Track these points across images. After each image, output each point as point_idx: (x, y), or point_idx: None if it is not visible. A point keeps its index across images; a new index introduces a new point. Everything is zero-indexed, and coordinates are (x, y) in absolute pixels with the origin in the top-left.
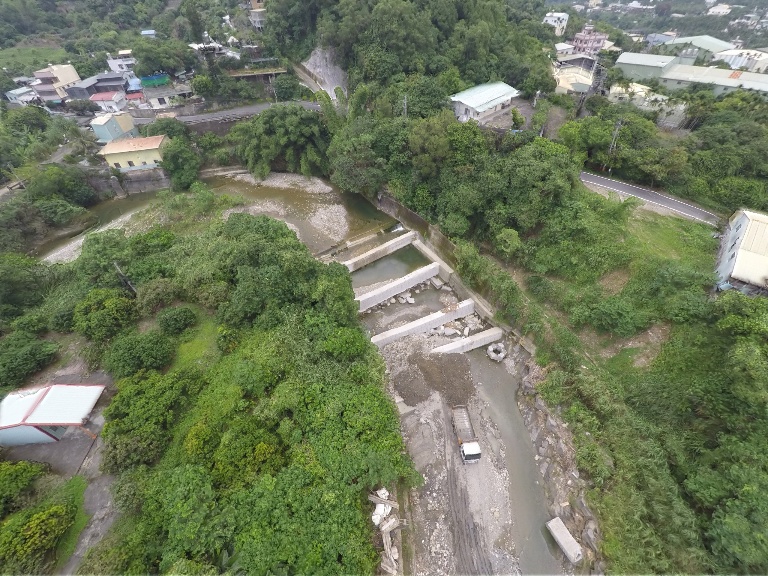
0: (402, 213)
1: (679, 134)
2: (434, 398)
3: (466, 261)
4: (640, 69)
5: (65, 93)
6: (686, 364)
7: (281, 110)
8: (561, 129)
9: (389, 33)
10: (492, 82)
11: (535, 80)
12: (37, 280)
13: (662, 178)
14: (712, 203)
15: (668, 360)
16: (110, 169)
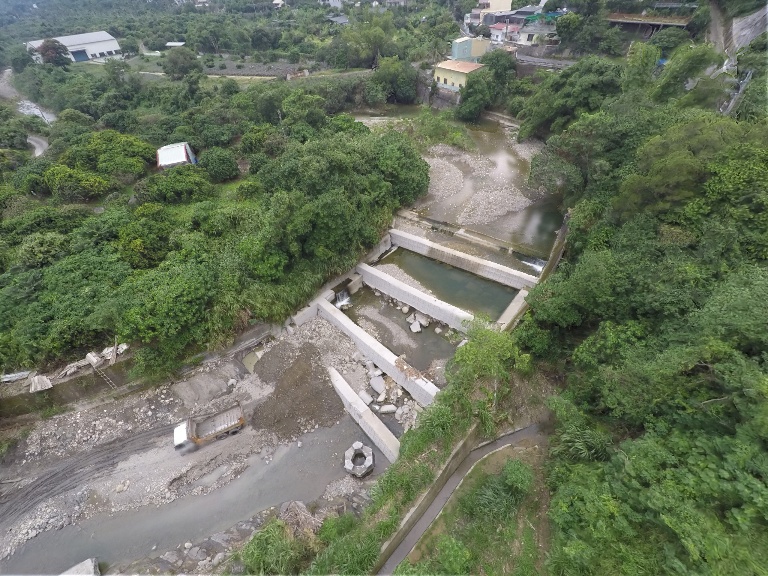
0: (557, 250)
1: None
2: (265, 388)
3: None
4: None
5: (483, 18)
6: None
7: (589, 64)
8: None
9: None
10: None
11: None
12: None
13: None
14: None
15: None
16: (433, 81)
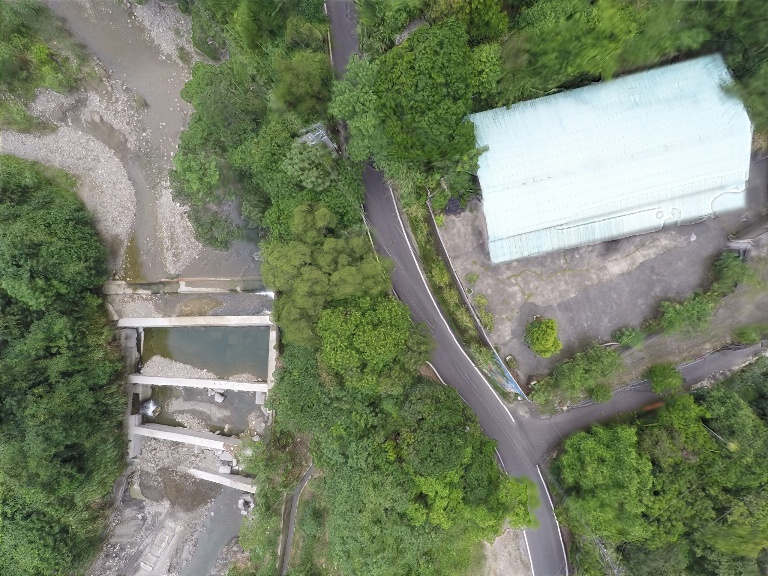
0: None
1: None
2: (164, 504)
3: None
4: None
5: None
6: None
7: None
8: (470, 517)
9: None
10: (723, 102)
11: None
12: None
13: None
14: None
15: None
16: None
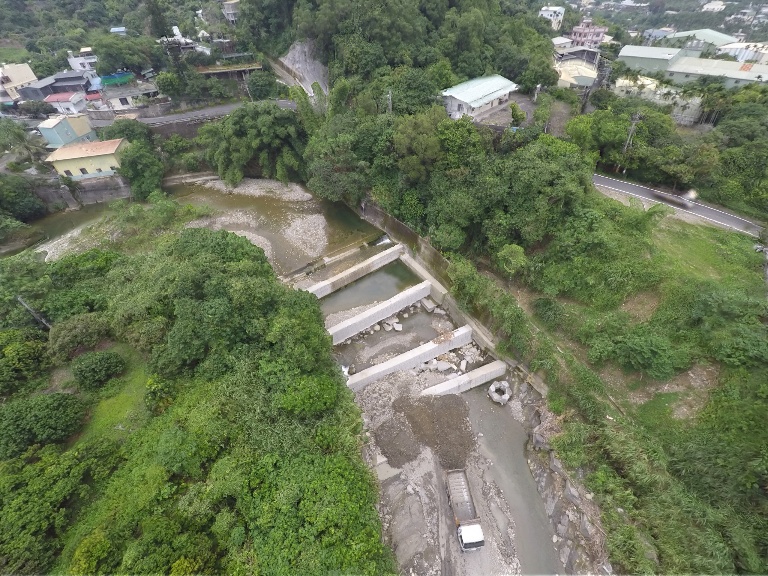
0: (388, 223)
1: (701, 129)
2: (425, 456)
3: (462, 281)
4: (645, 62)
5: (16, 94)
6: (747, 423)
7: (252, 109)
8: (570, 125)
9: (371, 21)
10: (487, 75)
11: (535, 72)
12: None
13: (689, 180)
14: (747, 208)
15: (721, 415)
16: (60, 177)
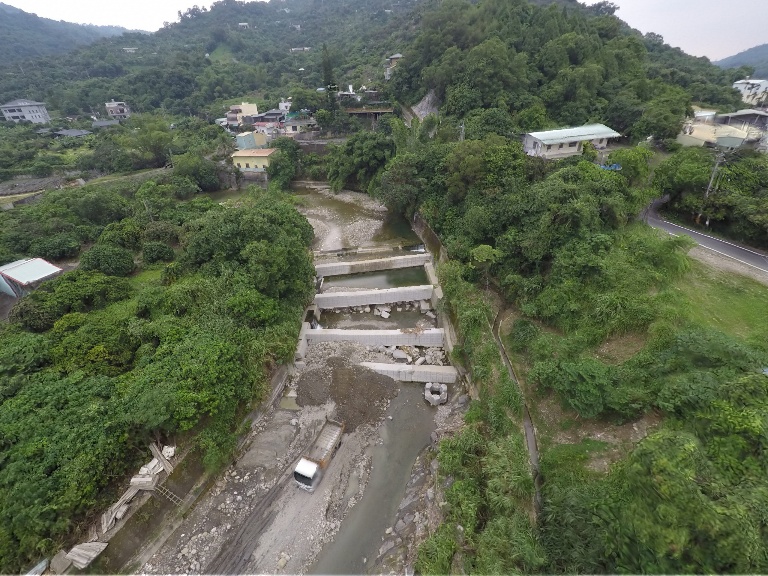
0: (427, 234)
1: None
2: (326, 408)
3: None
4: None
5: (241, 120)
6: None
7: (363, 135)
8: (617, 154)
9: (476, 72)
10: (589, 124)
11: (647, 123)
12: (119, 212)
13: None
14: None
15: (624, 466)
16: (234, 167)
